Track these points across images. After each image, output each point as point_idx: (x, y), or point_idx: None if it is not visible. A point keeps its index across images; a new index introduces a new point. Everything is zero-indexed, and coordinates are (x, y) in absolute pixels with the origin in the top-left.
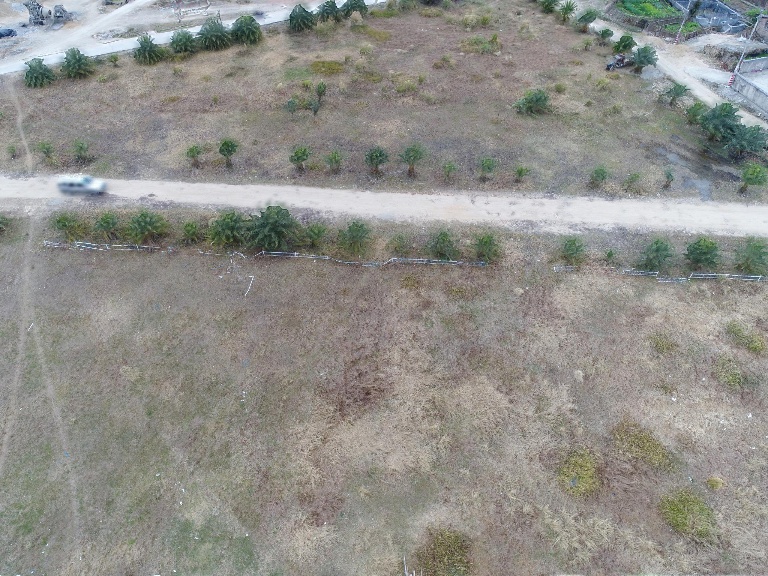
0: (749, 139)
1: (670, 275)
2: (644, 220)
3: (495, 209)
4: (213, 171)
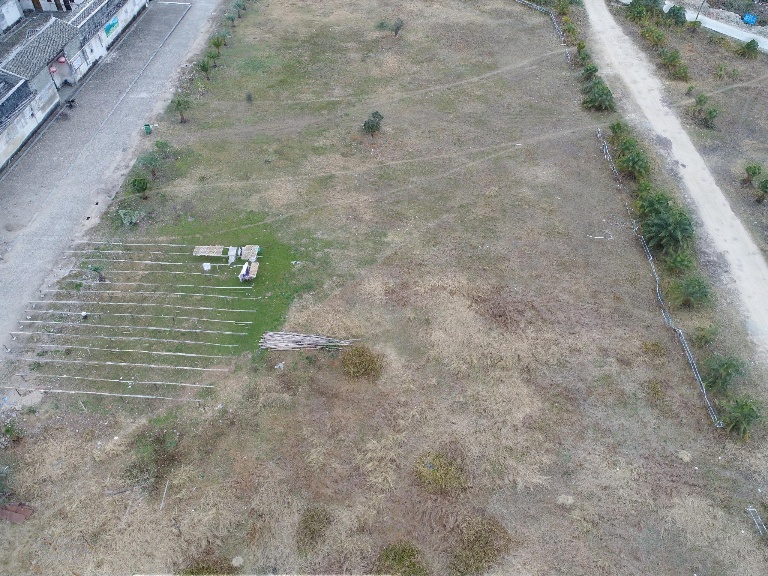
0: None
1: None
2: None
3: None
4: (744, 194)
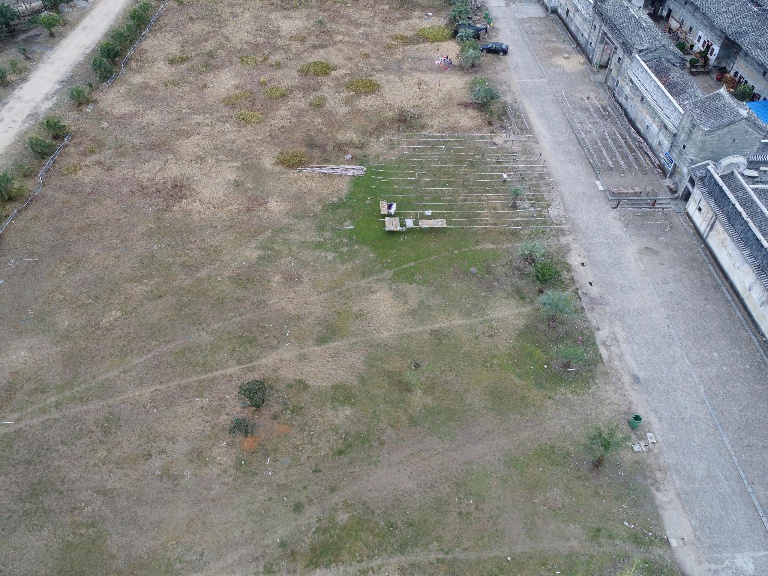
0: (7, 13)
1: (118, 72)
2: (59, 72)
3: (3, 128)
4: None
